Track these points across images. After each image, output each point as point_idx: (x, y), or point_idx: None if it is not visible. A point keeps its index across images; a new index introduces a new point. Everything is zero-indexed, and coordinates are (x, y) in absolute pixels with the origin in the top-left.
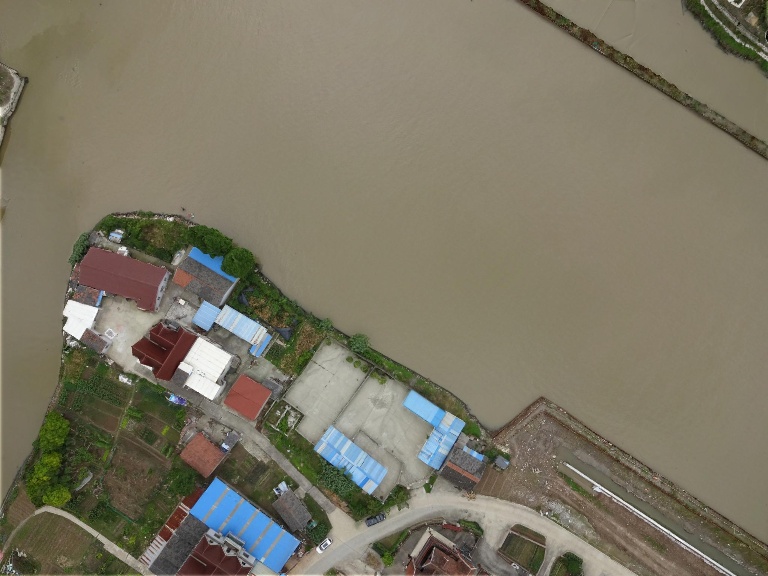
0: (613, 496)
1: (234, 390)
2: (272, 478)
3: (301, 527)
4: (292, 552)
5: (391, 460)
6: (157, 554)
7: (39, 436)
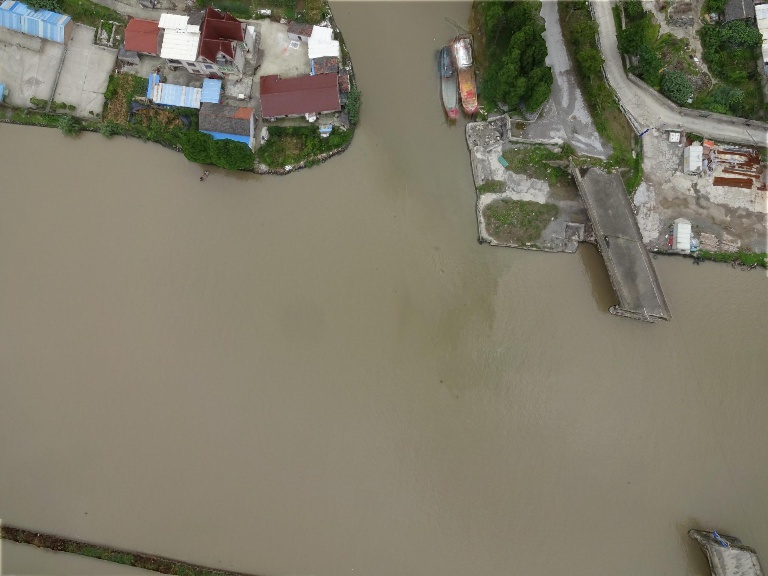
0: None
1: (154, 34)
2: None
3: None
4: None
5: (4, 38)
6: None
7: None
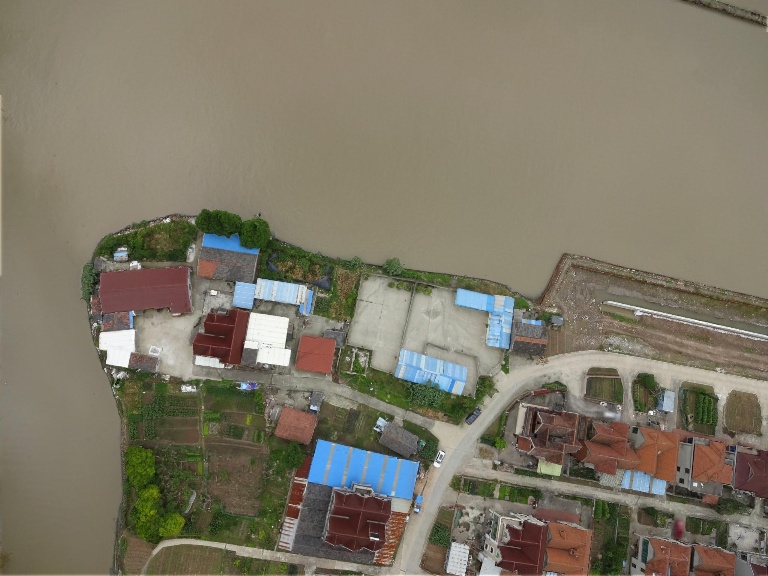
0: (654, 312)
1: (302, 351)
2: (367, 420)
3: (414, 449)
4: (416, 475)
5: (464, 359)
6: (293, 534)
7: (124, 479)
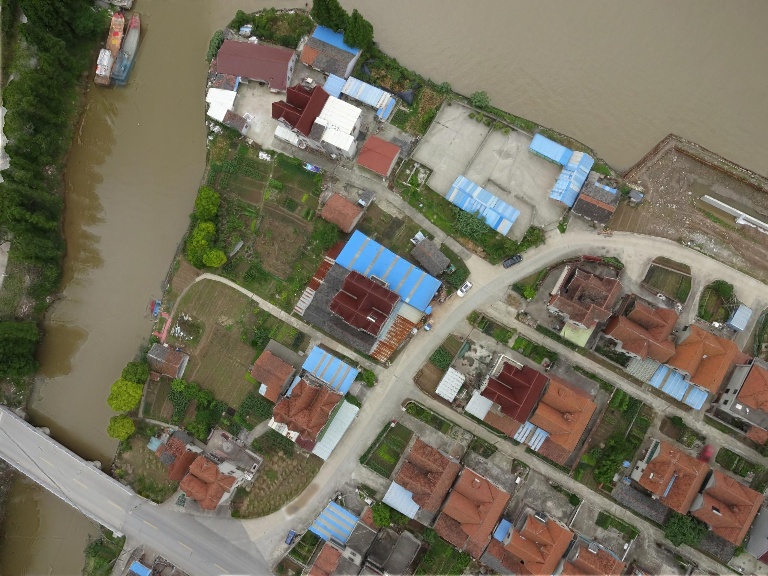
0: (759, 222)
1: (366, 146)
2: (408, 232)
3: (441, 268)
4: (435, 292)
5: (522, 206)
6: (308, 303)
7: None
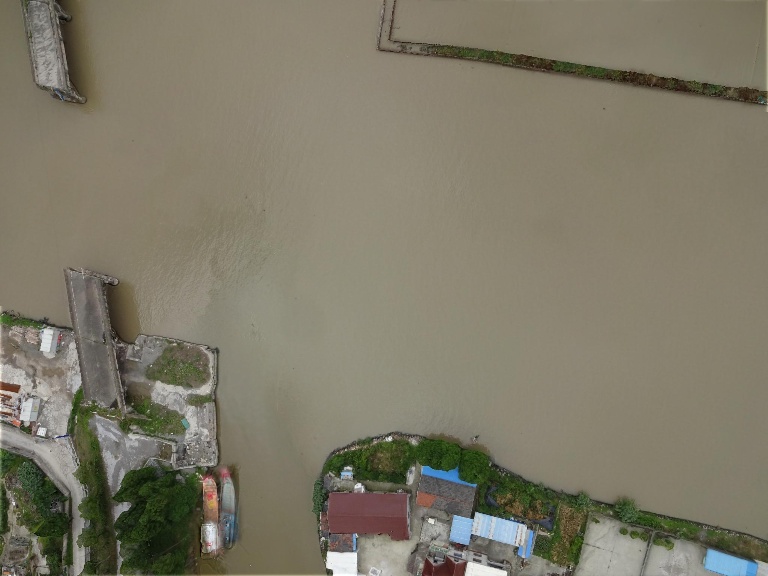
0: None
1: None
2: None
3: None
4: None
5: None
6: None
7: None
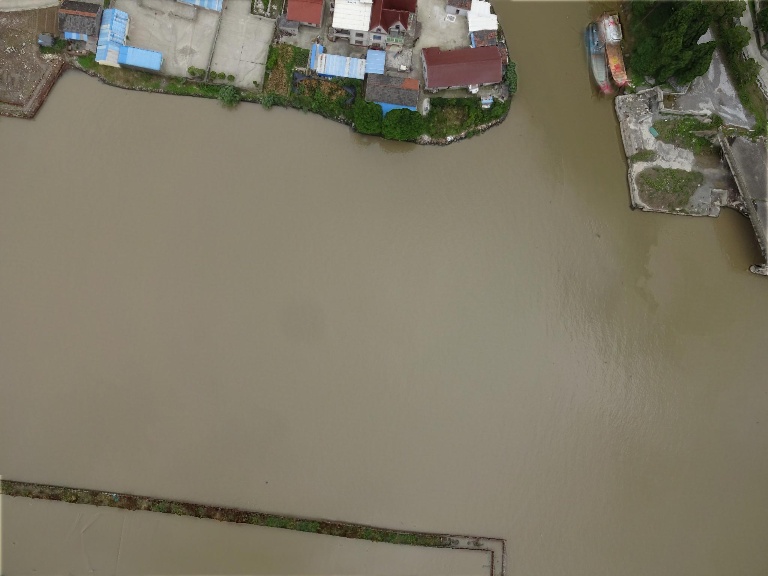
0: None
1: (319, 4)
2: None
3: None
4: None
5: (154, 6)
6: None
7: None
